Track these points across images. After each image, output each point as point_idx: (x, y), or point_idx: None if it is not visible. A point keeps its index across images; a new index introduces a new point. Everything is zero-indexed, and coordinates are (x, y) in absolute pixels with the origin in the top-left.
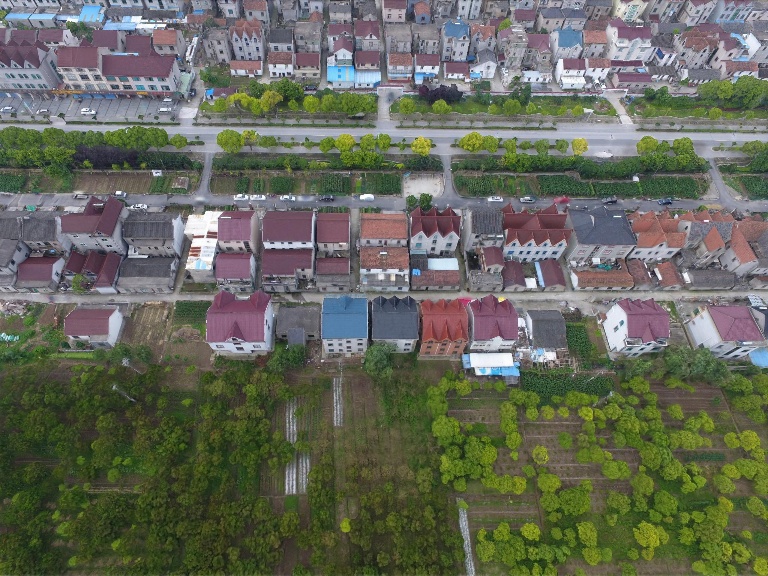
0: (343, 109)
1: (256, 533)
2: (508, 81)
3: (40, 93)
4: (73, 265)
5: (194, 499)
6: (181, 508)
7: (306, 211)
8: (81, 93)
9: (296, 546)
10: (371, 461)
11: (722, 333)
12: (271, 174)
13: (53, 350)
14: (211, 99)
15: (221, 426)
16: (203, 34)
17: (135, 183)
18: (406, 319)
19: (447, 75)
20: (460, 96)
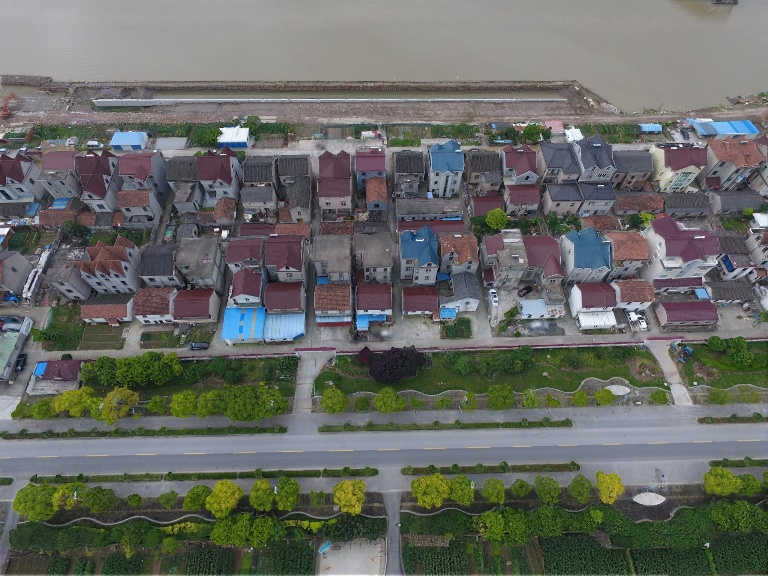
0: None
1: None
2: (498, 316)
3: None
4: None
5: None
6: None
7: None
8: None
9: None
10: None
11: None
12: (107, 546)
13: None
14: None
15: None
16: (58, 245)
17: None
18: None
19: (406, 311)
20: (421, 364)
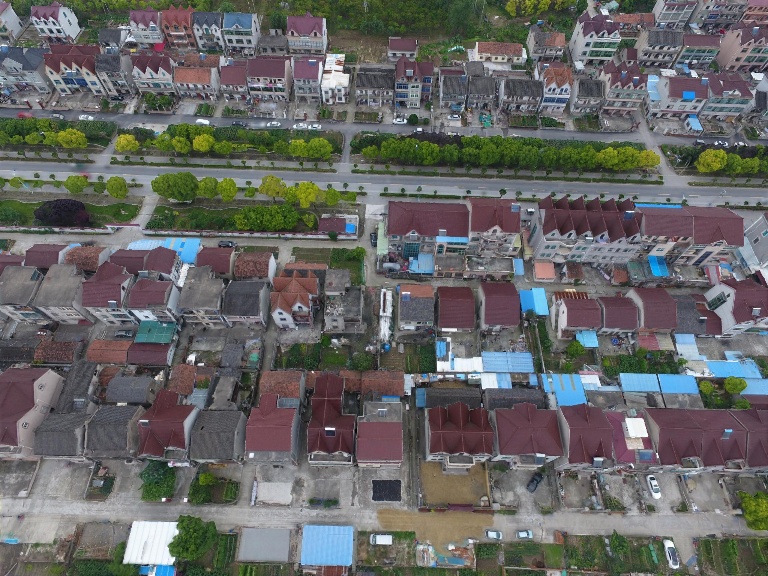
0: None
1: None
2: None
3: None
4: None
5: None
6: None
7: (253, 76)
8: None
9: None
10: None
11: (6, 5)
12: None
13: None
14: None
15: (320, 6)
16: None
17: None
18: None
19: None
20: None
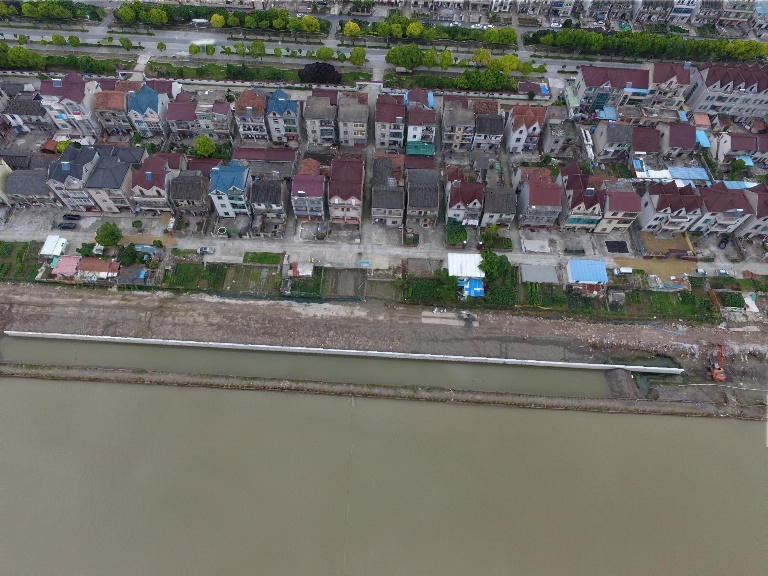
0: None
1: None
2: None
3: None
4: None
5: None
6: None
7: None
8: None
9: None
10: None
11: None
12: None
13: None
14: None
15: None
16: None
17: None
18: None
19: None
20: None
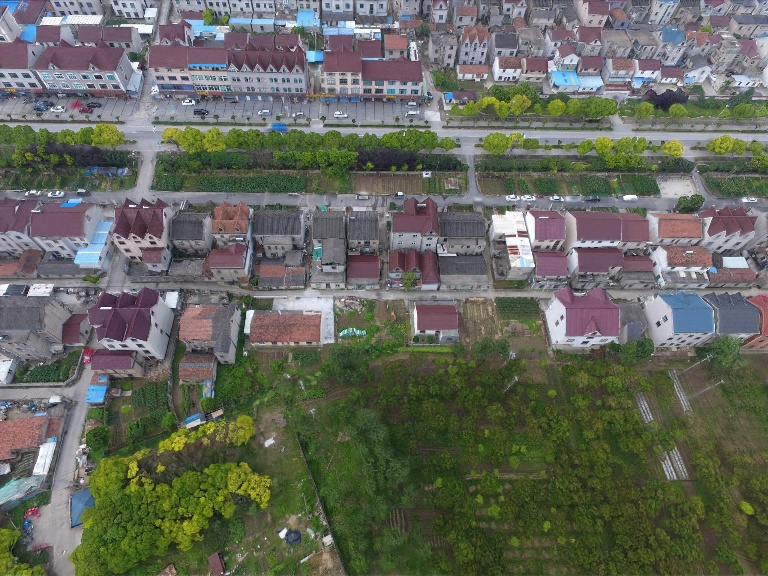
0: (590, 113)
1: (674, 515)
2: (717, 85)
3: (293, 97)
4: (400, 263)
5: (609, 484)
6: (595, 492)
7: None
8: (332, 97)
9: (707, 528)
10: (750, 448)
11: None
12: (532, 175)
13: (400, 344)
14: (449, 102)
15: (597, 416)
16: None
17: (407, 184)
18: (748, 314)
19: (661, 79)
20: None
